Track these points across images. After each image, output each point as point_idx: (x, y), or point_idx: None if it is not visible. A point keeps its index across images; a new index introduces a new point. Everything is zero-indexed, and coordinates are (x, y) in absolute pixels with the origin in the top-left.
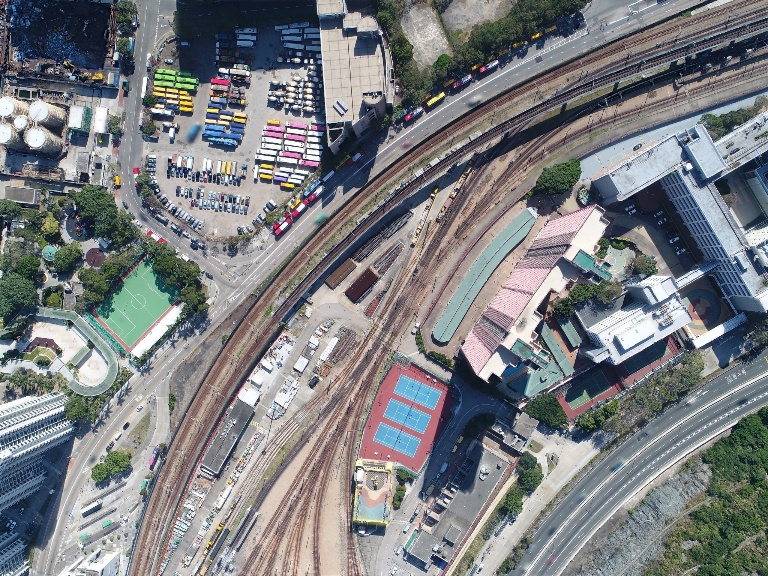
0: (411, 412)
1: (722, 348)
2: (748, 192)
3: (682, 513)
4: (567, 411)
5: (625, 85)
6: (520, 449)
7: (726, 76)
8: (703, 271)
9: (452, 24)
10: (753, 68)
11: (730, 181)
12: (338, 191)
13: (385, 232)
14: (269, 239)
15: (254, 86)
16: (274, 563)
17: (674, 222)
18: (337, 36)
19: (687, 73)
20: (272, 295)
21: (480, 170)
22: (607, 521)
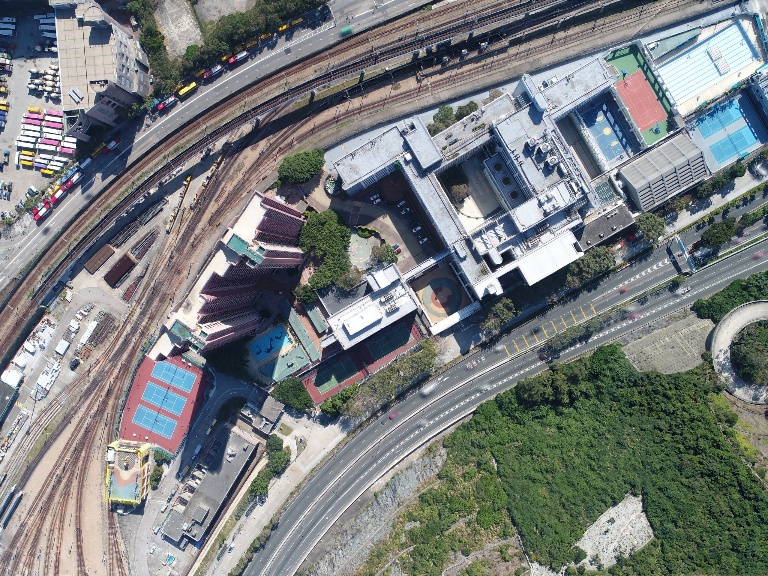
0: (168, 395)
1: (463, 335)
2: (487, 183)
3: (413, 495)
4: (316, 395)
5: (370, 77)
6: (268, 432)
7: (467, 69)
8: (435, 260)
9: (205, 15)
10: (492, 62)
11: (471, 172)
12: (97, 178)
13: (141, 219)
14: (31, 224)
15: (16, 74)
16: (39, 541)
17: (416, 212)
18: (72, 25)
19: (428, 66)
20: (34, 279)
21: (232, 159)
22: (354, 503)
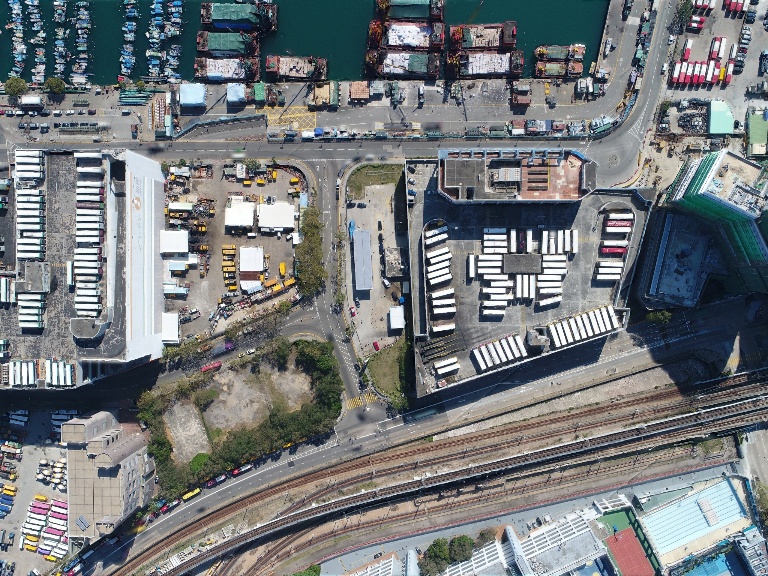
0: None
1: None
2: None
3: None
4: None
5: None
6: None
7: (463, 499)
8: None
9: (212, 422)
10: (489, 494)
11: None
12: (98, 566)
13: None
14: None
15: (25, 460)
16: None
17: None
18: (83, 457)
19: (426, 494)
20: None
21: (231, 561)
22: None
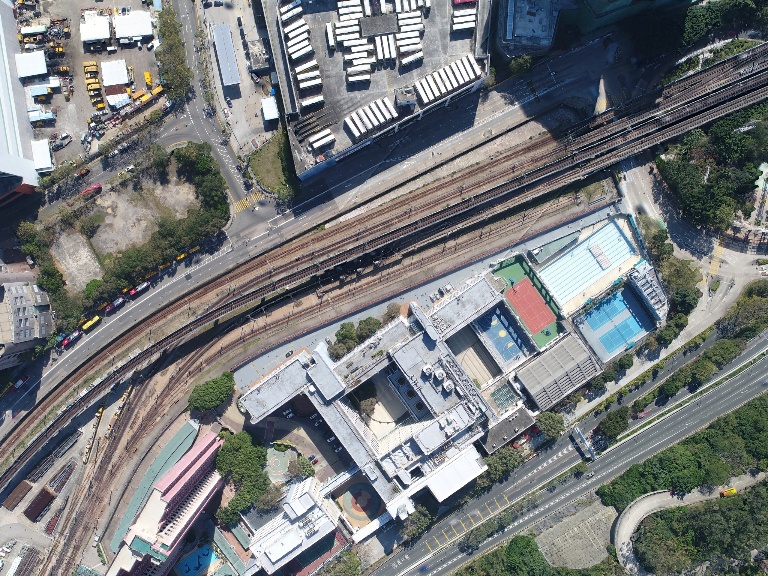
0: None
1: (386, 536)
2: None
3: None
4: None
5: (271, 297)
6: None
7: (364, 282)
8: (350, 474)
9: (102, 248)
10: (388, 274)
11: (378, 380)
12: (7, 415)
13: (56, 452)
14: None
15: None
16: None
17: None
18: None
19: (326, 283)
20: None
21: (143, 386)
22: None
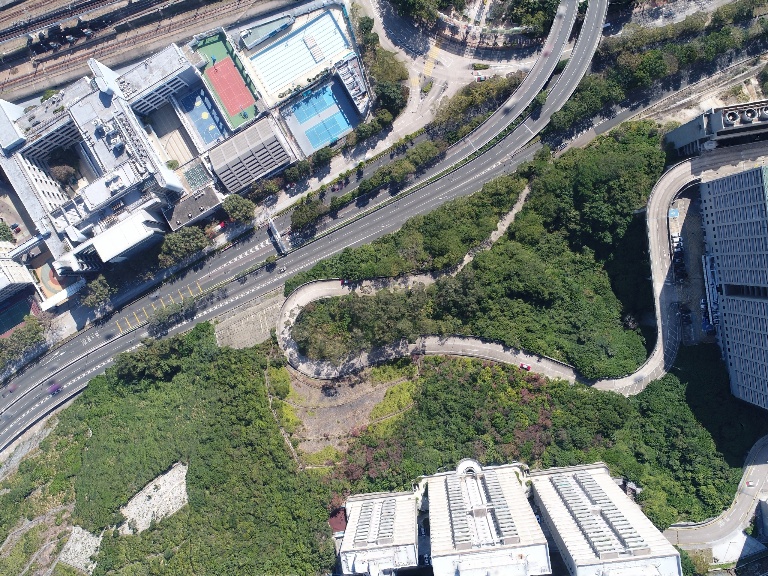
0: None
1: (79, 312)
2: None
3: (17, 465)
4: None
5: None
6: None
7: (79, 55)
8: (38, 238)
9: None
10: (102, 48)
11: None
12: None
13: None
14: None
15: None
16: None
17: None
18: None
19: (41, 51)
20: None
21: None
22: None
